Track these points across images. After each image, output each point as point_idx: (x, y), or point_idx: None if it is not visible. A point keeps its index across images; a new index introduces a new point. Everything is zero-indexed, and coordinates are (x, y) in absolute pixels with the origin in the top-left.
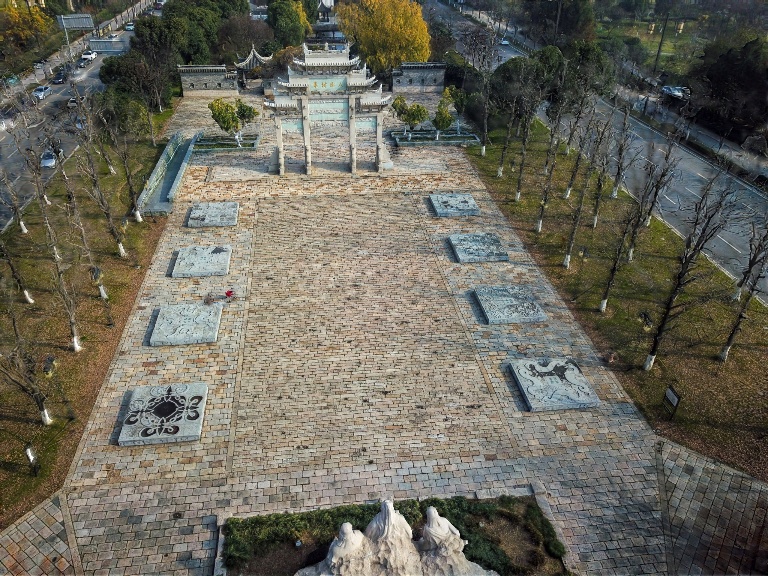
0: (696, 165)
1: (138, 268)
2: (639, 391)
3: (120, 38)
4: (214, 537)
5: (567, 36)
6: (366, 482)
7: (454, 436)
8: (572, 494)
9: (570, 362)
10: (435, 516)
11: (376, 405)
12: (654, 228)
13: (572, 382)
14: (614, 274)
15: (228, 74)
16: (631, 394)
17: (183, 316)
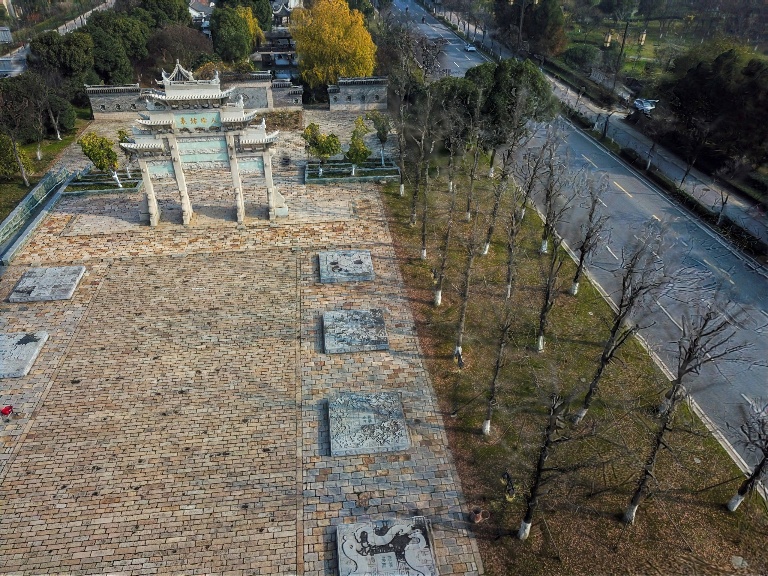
0: (653, 203)
1: None
2: None
3: (19, 56)
4: None
5: (537, 41)
6: None
7: None
8: None
9: (418, 527)
10: None
11: None
12: (583, 297)
13: (411, 565)
14: (494, 391)
15: (143, 94)
16: None
17: None
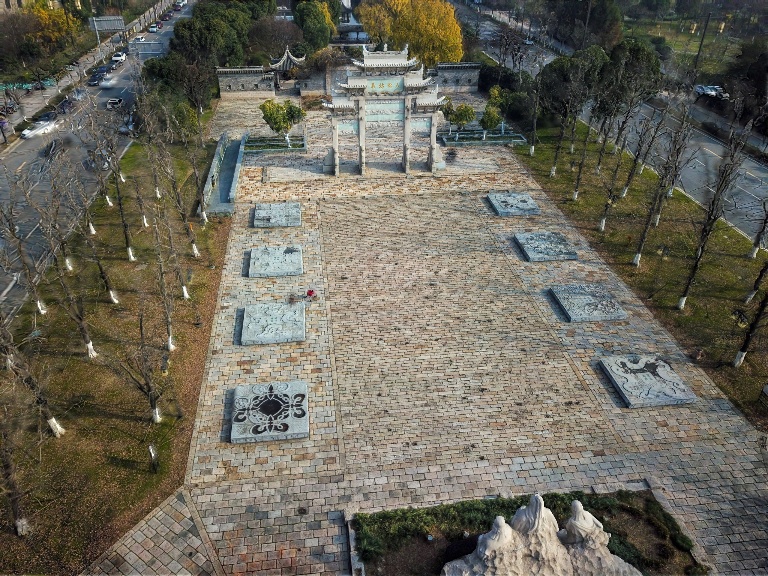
0: None
1: (213, 268)
2: (732, 387)
3: (159, 40)
4: (342, 532)
5: None
6: (481, 478)
7: (558, 432)
8: (686, 489)
9: (660, 359)
10: (581, 509)
11: (476, 402)
12: None
13: (666, 379)
14: (695, 272)
15: (265, 75)
16: (725, 390)
17: (269, 315)
